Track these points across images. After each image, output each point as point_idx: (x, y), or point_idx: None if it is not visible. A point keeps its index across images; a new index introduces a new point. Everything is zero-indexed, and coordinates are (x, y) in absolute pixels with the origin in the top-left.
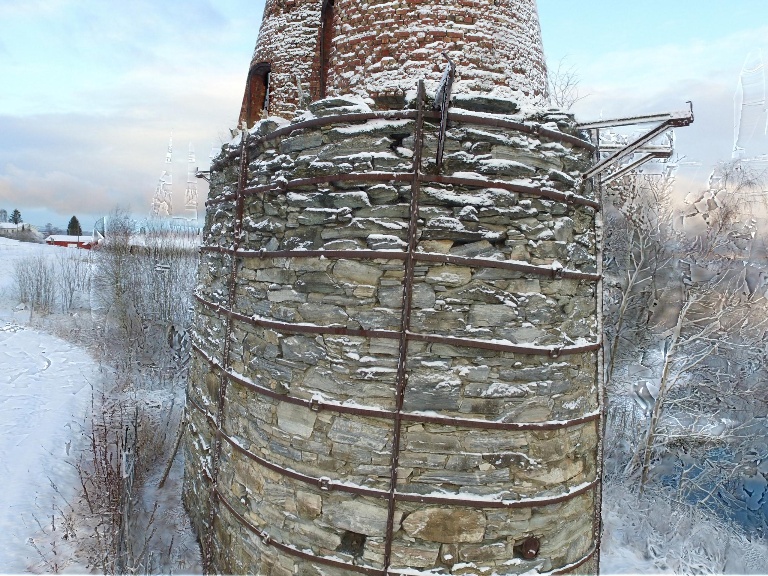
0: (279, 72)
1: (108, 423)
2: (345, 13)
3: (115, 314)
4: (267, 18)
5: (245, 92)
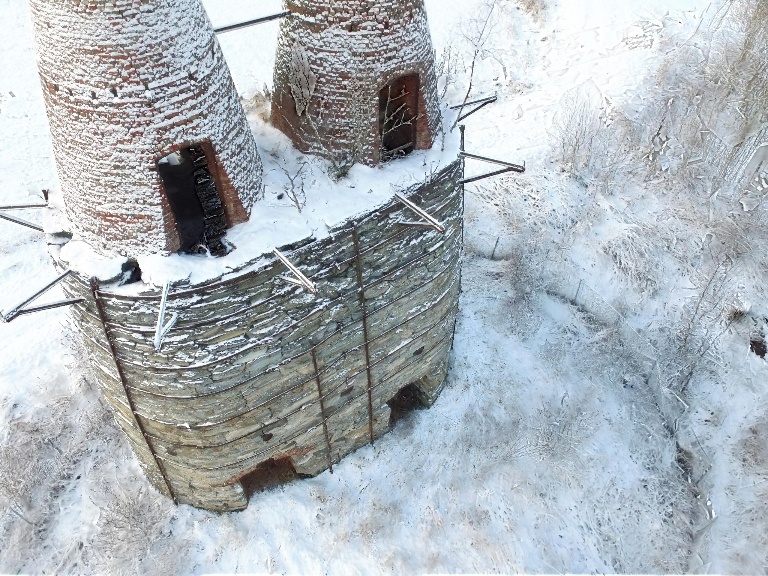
0: None
1: (486, 189)
2: None
3: (567, 100)
4: None
5: None
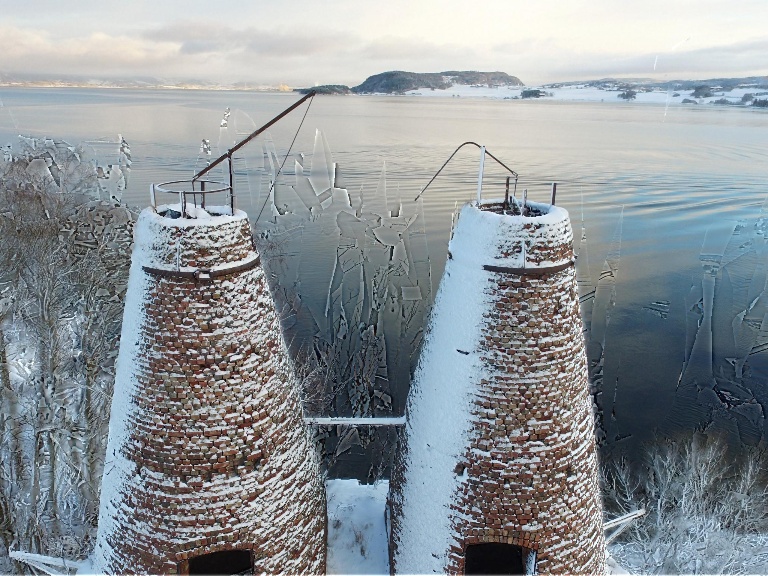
0: (271, 556)
1: None
2: None
3: None
4: (203, 479)
5: None
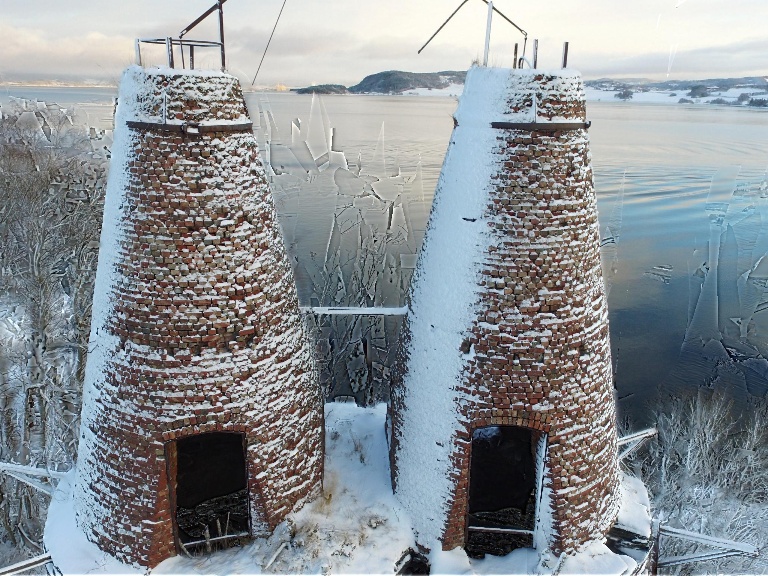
0: (265, 442)
1: None
2: (572, 466)
3: None
4: (191, 352)
5: (162, 472)
